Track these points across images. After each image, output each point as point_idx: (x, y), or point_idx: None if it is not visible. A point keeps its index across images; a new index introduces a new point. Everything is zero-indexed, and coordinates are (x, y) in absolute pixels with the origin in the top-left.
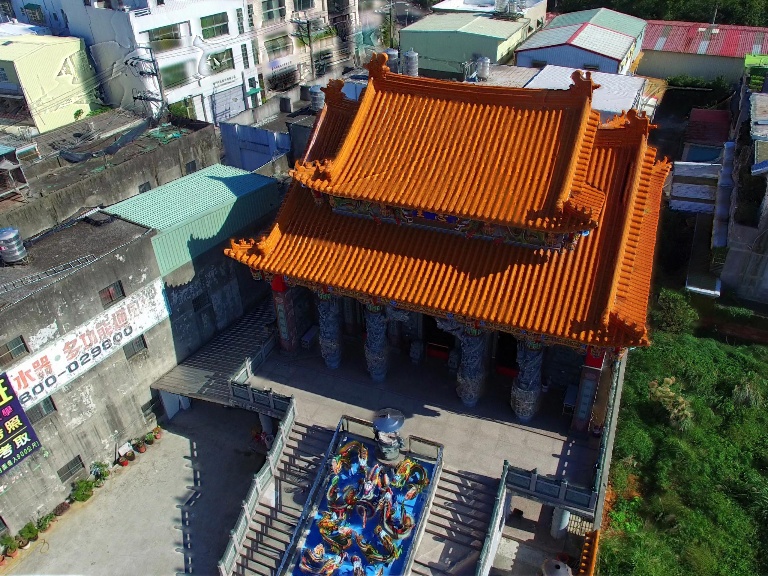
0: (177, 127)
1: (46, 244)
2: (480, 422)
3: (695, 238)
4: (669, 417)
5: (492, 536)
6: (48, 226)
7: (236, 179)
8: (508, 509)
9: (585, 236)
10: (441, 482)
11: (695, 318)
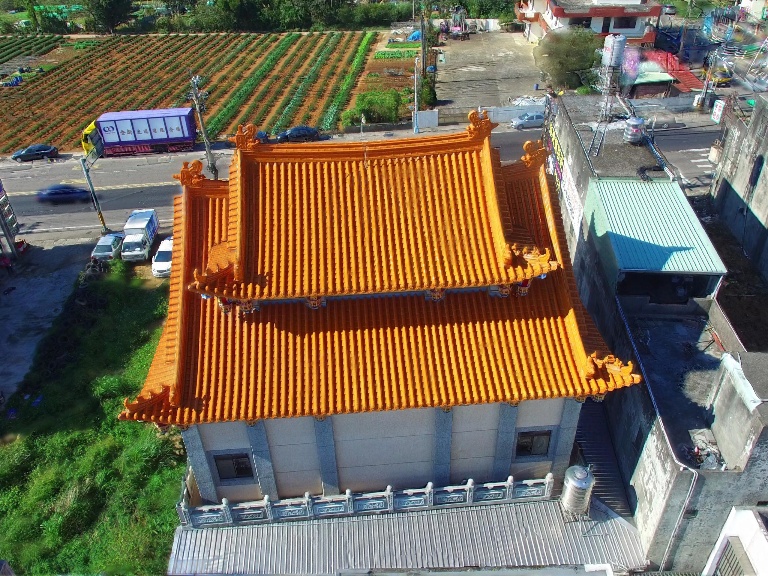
0: None
1: (642, 153)
2: None
3: None
4: None
5: None
6: None
7: (658, 254)
8: None
9: None
10: None
11: None
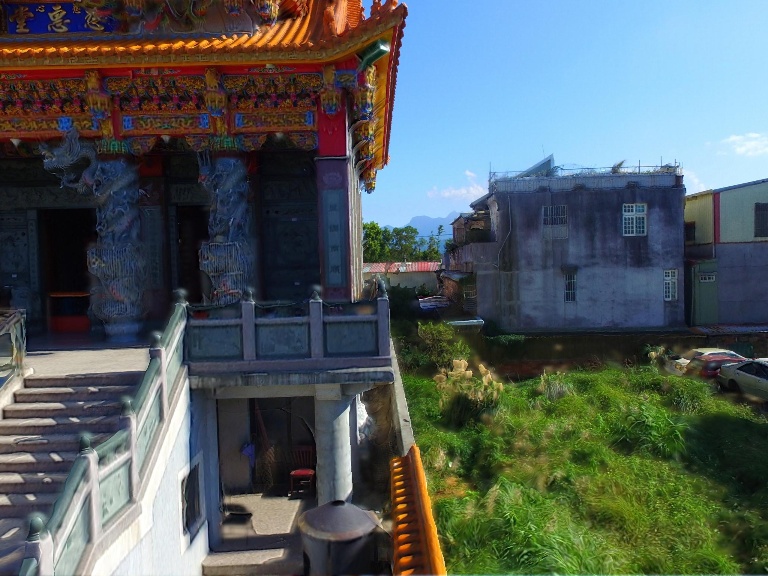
0: None
1: None
2: (142, 349)
3: (440, 312)
4: (476, 406)
5: (147, 462)
6: None
7: None
8: (213, 506)
9: (287, 30)
10: (15, 404)
11: (466, 350)
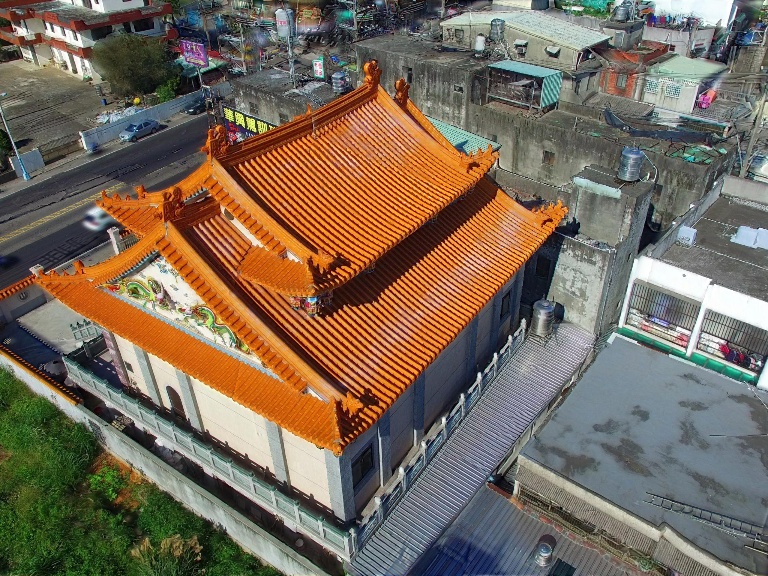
0: (671, 144)
1: None
2: None
3: None
4: None
5: None
6: (511, 138)
7: None
8: None
9: None
10: None
11: None
